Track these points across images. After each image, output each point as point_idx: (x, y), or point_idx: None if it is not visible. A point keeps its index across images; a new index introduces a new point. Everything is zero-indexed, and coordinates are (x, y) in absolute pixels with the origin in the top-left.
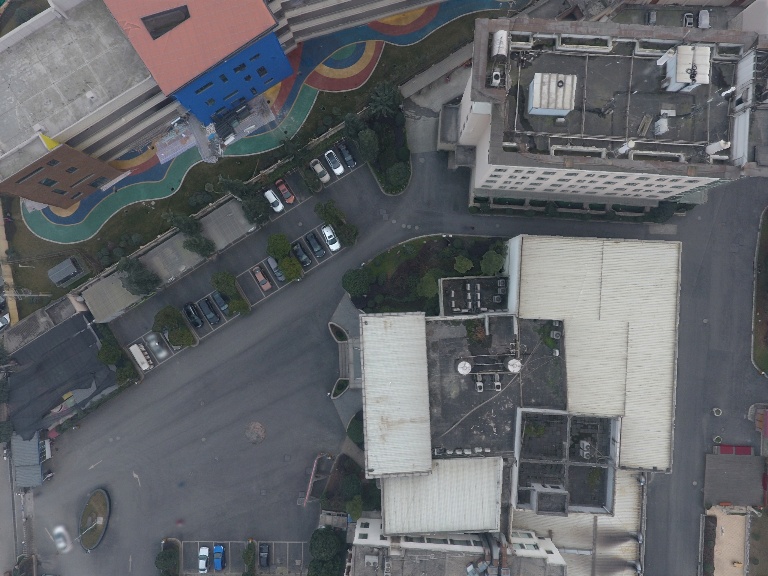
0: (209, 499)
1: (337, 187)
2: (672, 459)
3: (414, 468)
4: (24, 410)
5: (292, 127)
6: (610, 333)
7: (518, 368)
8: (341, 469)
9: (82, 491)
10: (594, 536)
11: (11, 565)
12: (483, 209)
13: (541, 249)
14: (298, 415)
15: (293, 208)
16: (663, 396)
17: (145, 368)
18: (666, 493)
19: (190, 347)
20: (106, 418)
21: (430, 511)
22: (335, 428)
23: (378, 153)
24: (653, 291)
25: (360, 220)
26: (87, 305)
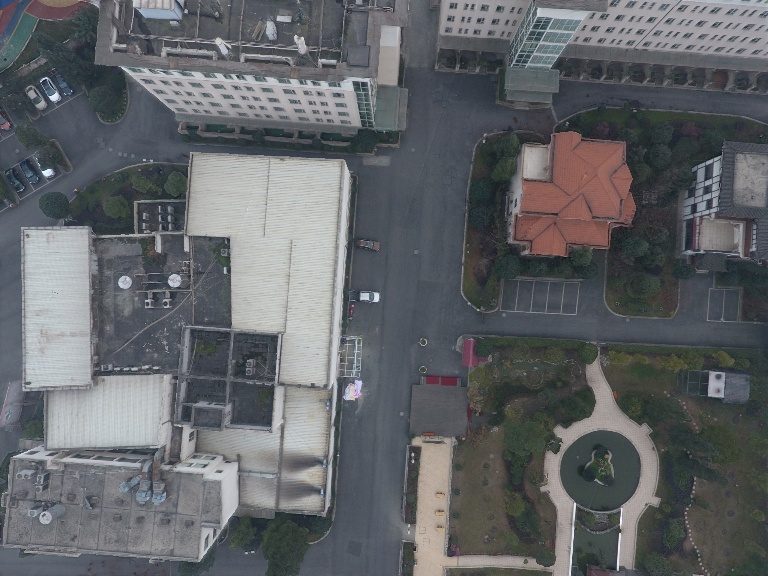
0: None
1: (55, 115)
2: (329, 376)
3: (72, 382)
4: None
5: (11, 55)
6: (274, 250)
7: (178, 283)
8: None
9: None
10: (279, 460)
11: None
12: (192, 136)
13: (210, 166)
14: (9, 341)
15: (11, 135)
16: (323, 313)
17: None
18: (373, 423)
19: None
20: None
21: (93, 427)
22: None
23: (85, 78)
24: (316, 208)
25: (77, 148)
26: None
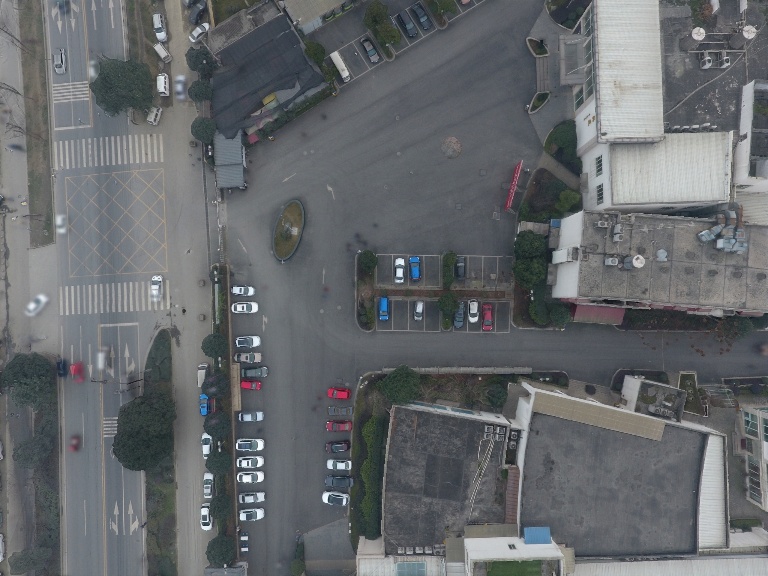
0: (404, 213)
1: None
2: None
3: (646, 133)
4: (226, 111)
5: None
6: None
7: (753, 34)
8: (540, 180)
9: (276, 203)
10: None
11: (204, 275)
12: None
13: None
14: (494, 130)
15: None
16: None
17: (345, 75)
18: None
19: (386, 62)
20: (300, 131)
21: (658, 182)
22: (532, 143)
23: None
24: None
25: None
26: (287, 12)
